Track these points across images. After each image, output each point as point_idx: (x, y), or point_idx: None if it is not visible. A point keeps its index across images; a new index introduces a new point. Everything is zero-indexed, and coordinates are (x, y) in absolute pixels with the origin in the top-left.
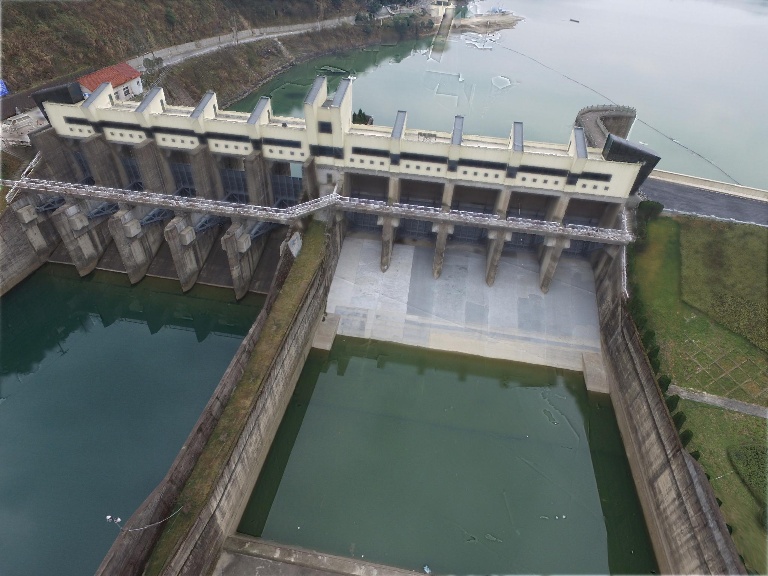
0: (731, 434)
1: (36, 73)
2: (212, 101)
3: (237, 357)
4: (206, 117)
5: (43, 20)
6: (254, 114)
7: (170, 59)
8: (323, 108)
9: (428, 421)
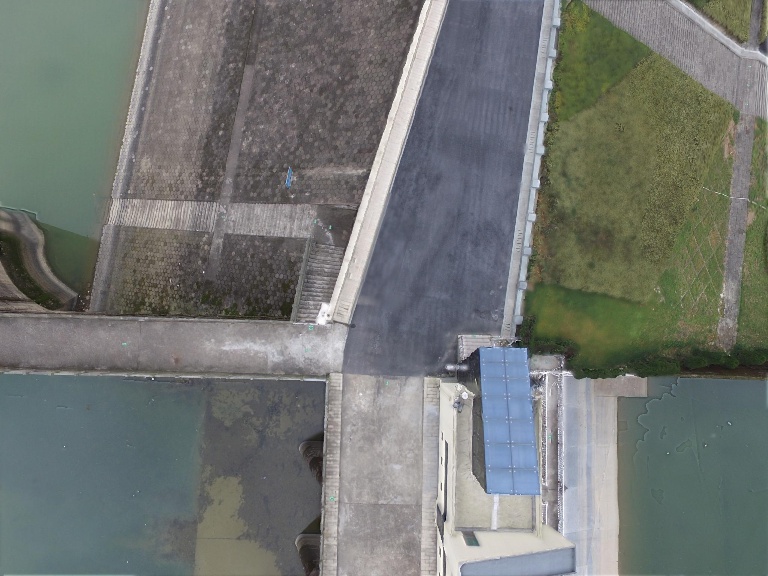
0: (763, 284)
1: None
2: None
3: None
4: None
5: None
6: None
7: None
8: None
9: None
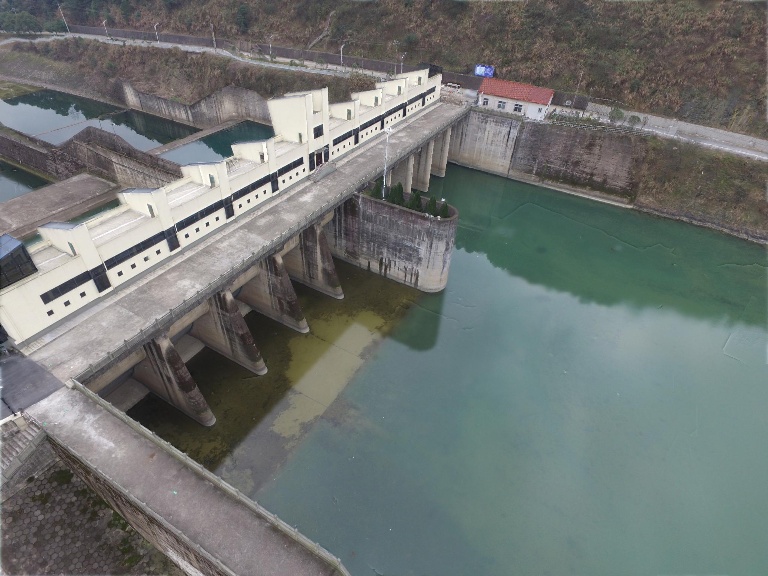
0: None
1: (531, 77)
2: (375, 93)
3: None
4: (362, 99)
5: (601, 48)
6: None
7: (674, 131)
8: None
9: None
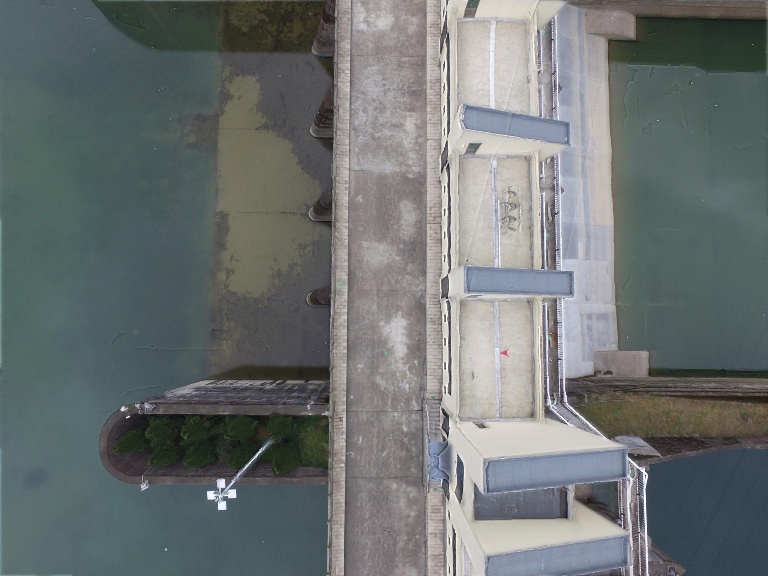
0: None
1: None
2: None
3: None
4: None
5: None
6: None
7: None
8: (574, 506)
9: (712, 220)
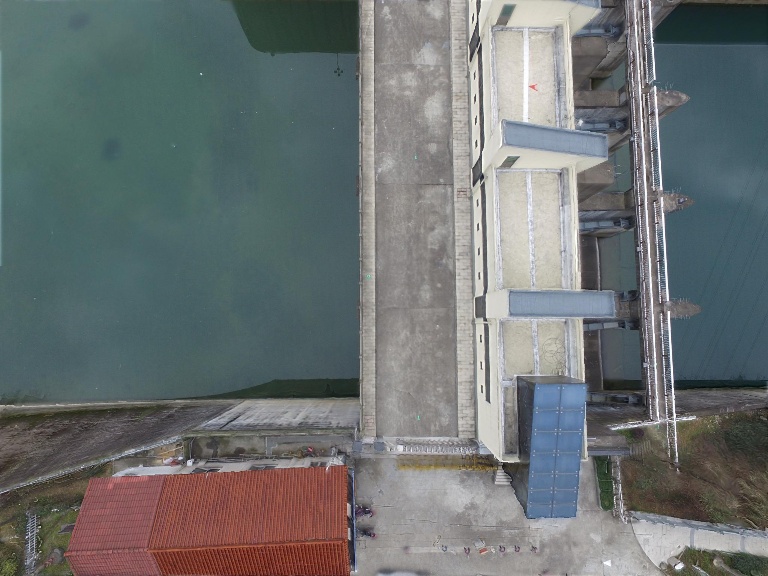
0: None
1: None
2: None
3: None
4: None
5: None
6: None
7: None
8: None
9: None
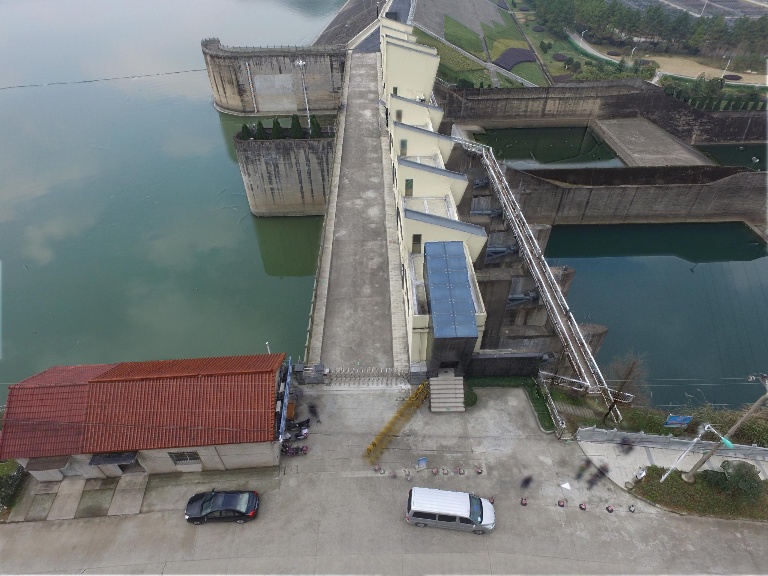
0: None
1: None
2: None
3: (617, 186)
4: None
5: None
6: (424, 106)
7: None
8: None
9: None
